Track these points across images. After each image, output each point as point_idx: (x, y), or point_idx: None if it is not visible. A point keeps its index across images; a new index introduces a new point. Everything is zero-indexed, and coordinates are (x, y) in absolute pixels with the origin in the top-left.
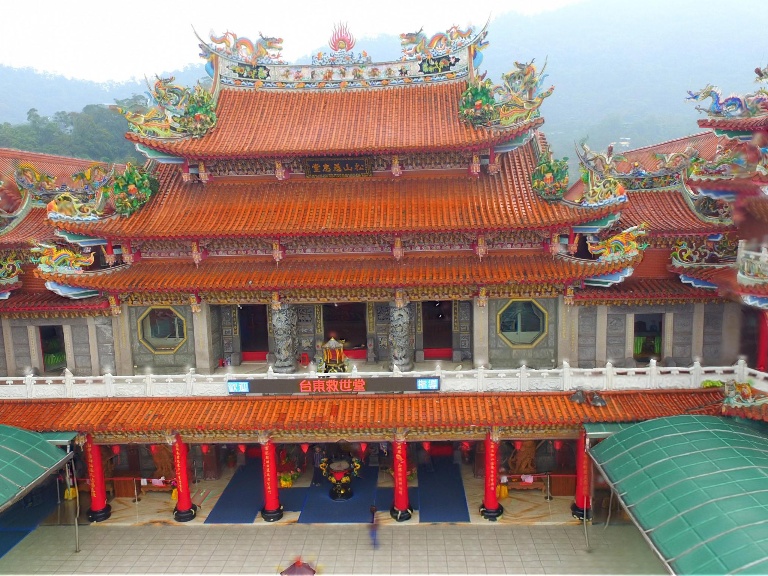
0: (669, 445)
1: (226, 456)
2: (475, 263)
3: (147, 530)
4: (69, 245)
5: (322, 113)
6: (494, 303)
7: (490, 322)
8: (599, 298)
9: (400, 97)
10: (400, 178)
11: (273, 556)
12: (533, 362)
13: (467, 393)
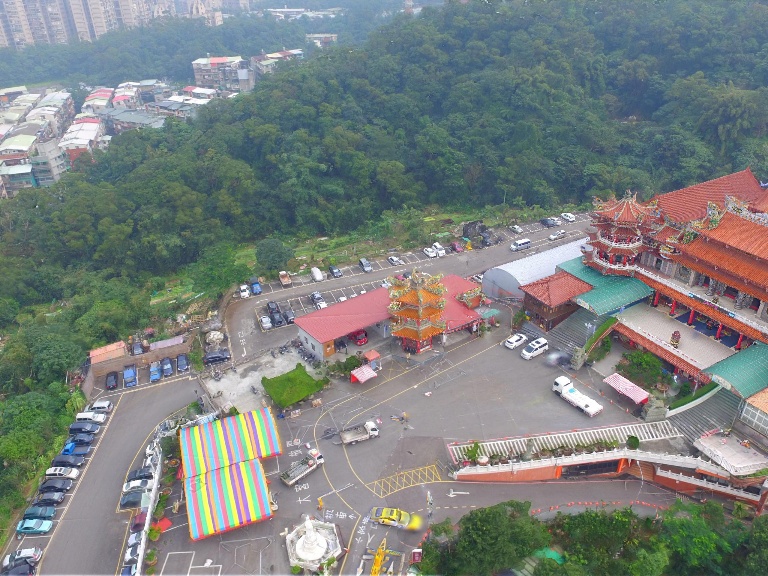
0: None
1: None
2: (765, 292)
3: (663, 314)
4: None
5: (749, 232)
6: (767, 304)
7: (764, 308)
8: None
9: None
10: (760, 260)
11: (683, 331)
12: None
13: (740, 321)
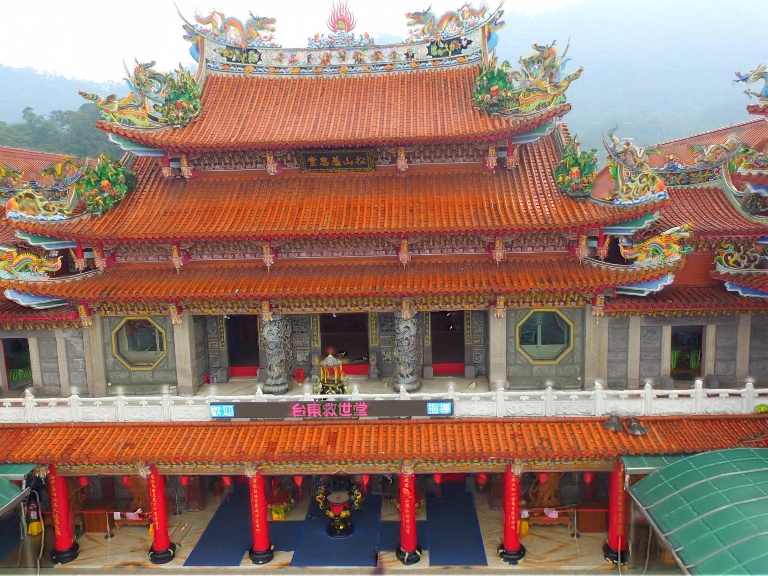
0: (729, 487)
1: (212, 483)
2: (491, 268)
3: (118, 574)
4: (33, 248)
5: (319, 101)
6: (513, 314)
7: (508, 335)
8: (633, 309)
9: (406, 83)
10: (406, 173)
11: None
12: (556, 380)
13: (484, 418)
